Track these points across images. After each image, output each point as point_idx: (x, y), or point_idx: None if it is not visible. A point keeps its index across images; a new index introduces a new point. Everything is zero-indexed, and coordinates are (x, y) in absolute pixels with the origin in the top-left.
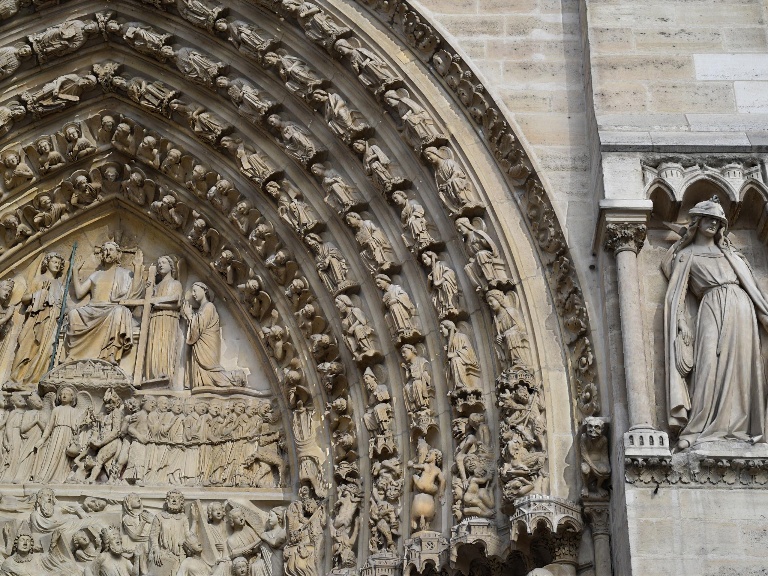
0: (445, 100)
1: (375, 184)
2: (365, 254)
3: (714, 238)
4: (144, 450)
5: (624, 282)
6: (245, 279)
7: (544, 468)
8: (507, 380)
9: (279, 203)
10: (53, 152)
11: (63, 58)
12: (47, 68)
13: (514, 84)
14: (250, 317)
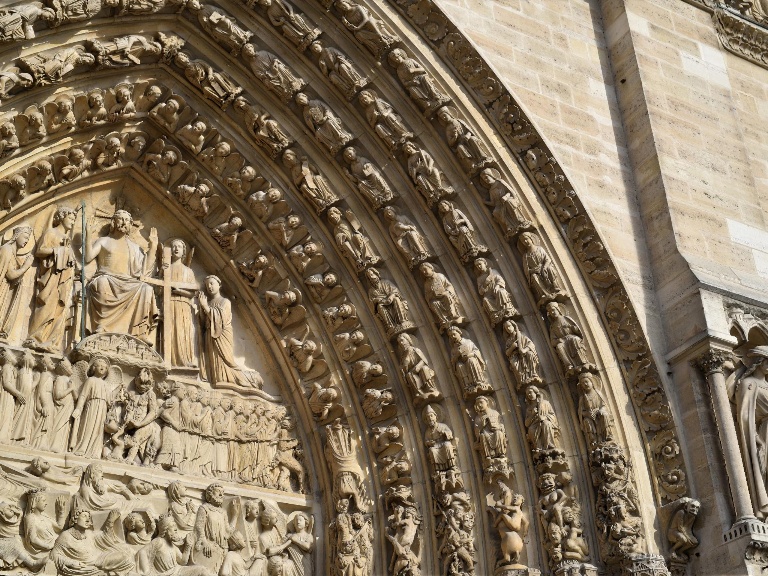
0: (532, 192)
1: (459, 245)
2: (440, 304)
3: (765, 375)
4: (179, 437)
5: (723, 398)
6: (268, 285)
7: (641, 531)
8: (610, 453)
9: (338, 229)
10: (102, 108)
11: (136, 17)
12: (118, 21)
13: (596, 198)
14: (271, 323)
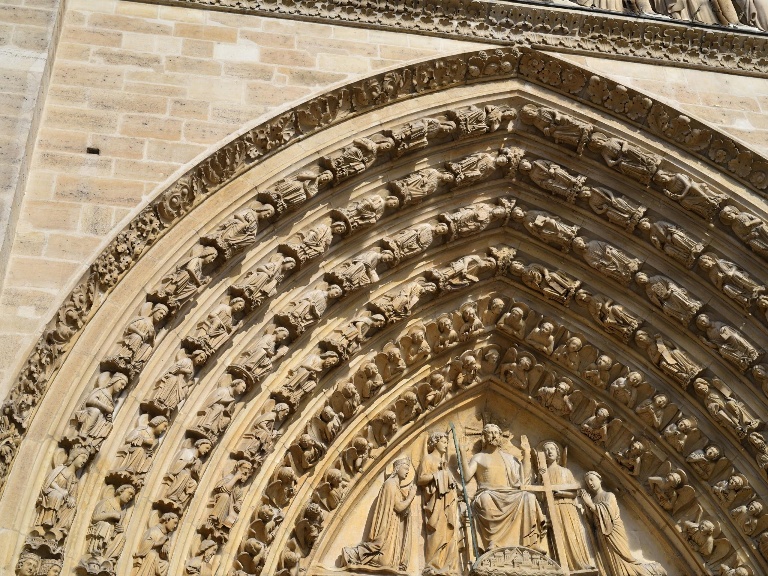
0: None
1: None
2: None
3: None
4: None
5: None
6: (649, 471)
7: None
8: None
9: (708, 400)
10: (452, 331)
11: (466, 238)
12: (451, 247)
13: None
14: (661, 510)
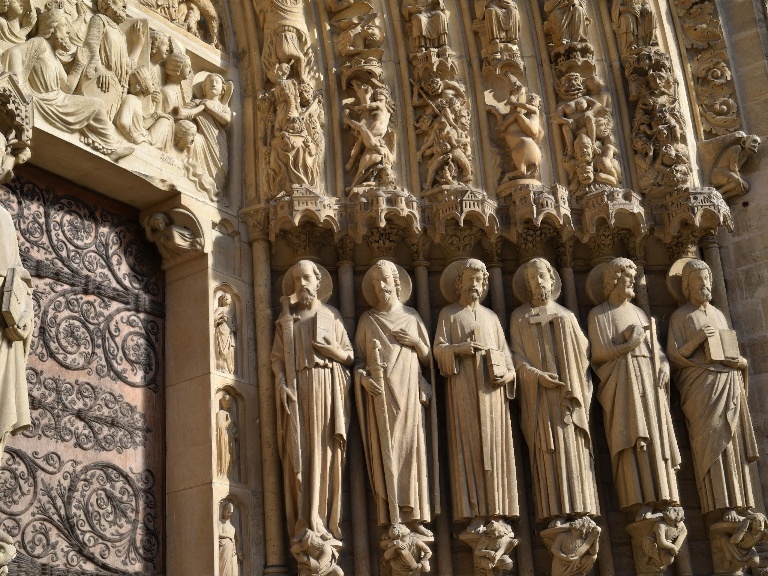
0: None
1: None
2: None
3: None
4: None
5: None
6: None
7: (688, 163)
8: (661, 59)
9: None
10: None
11: None
12: None
13: None
14: None
